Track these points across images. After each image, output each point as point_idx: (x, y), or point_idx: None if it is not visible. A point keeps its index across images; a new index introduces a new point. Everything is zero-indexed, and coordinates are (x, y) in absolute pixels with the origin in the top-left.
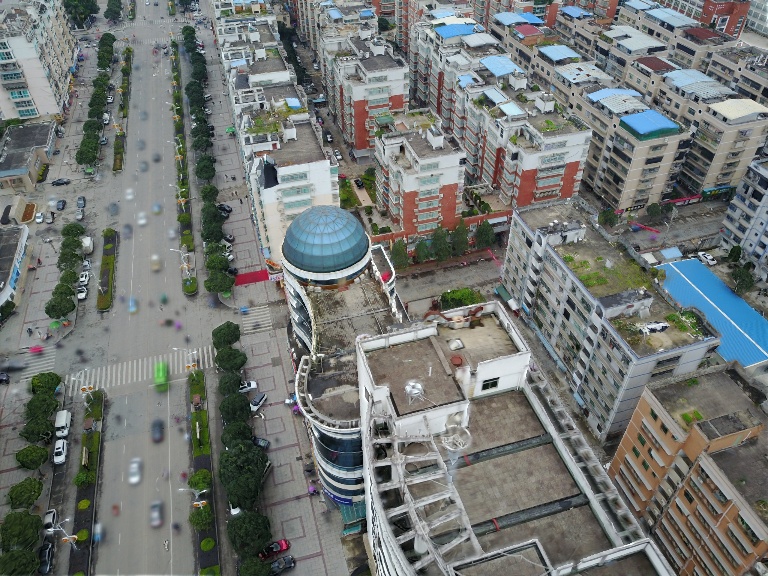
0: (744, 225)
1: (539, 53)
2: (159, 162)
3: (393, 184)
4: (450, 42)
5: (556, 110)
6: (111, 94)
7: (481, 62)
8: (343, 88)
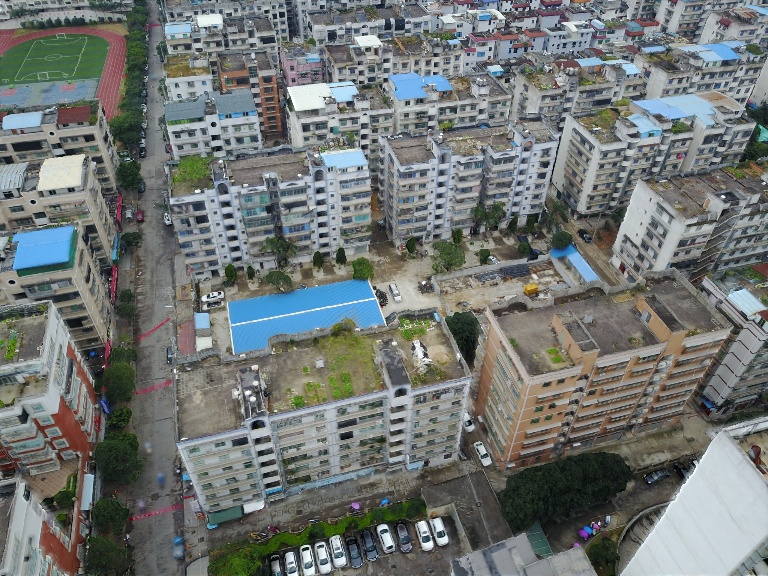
0: (211, 249)
1: None
2: None
3: None
4: None
5: None
6: None
7: None
8: None
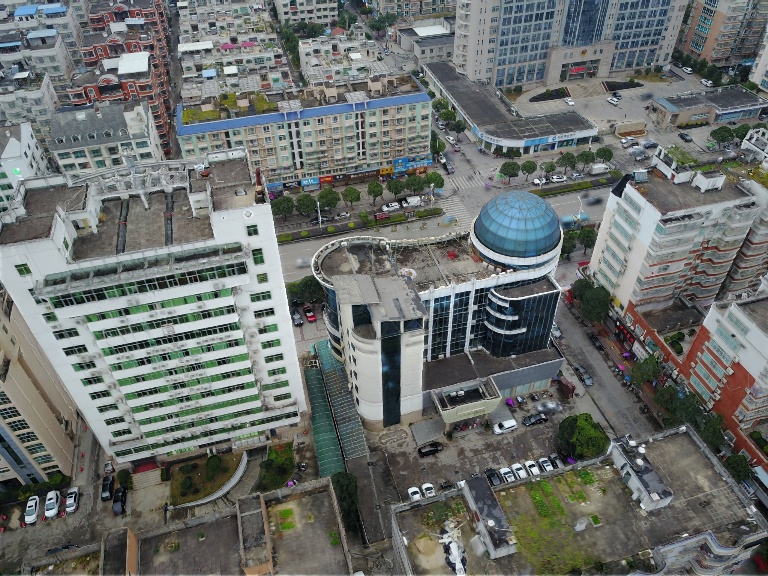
0: None
1: None
2: None
3: None
4: None
5: None
6: None
7: None
8: None
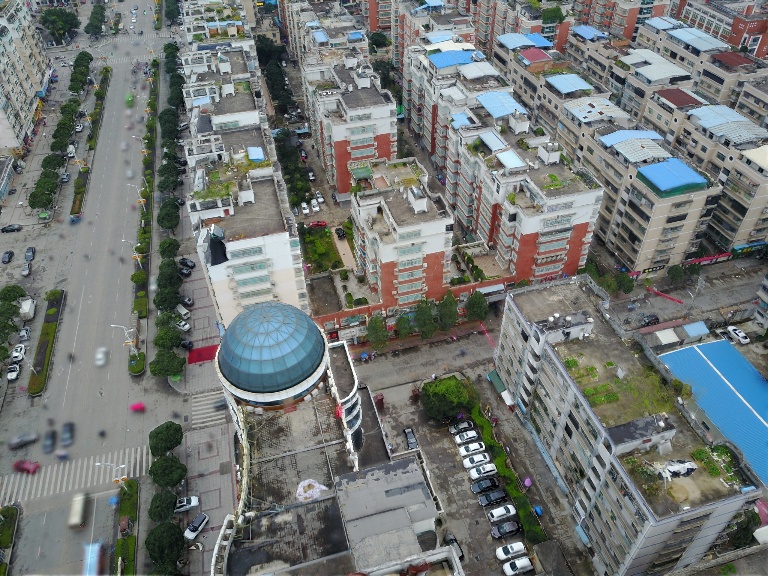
0: None
1: (546, 83)
2: (122, 204)
3: (369, 251)
4: (445, 72)
5: (562, 161)
6: (81, 121)
7: (477, 99)
8: (322, 126)
